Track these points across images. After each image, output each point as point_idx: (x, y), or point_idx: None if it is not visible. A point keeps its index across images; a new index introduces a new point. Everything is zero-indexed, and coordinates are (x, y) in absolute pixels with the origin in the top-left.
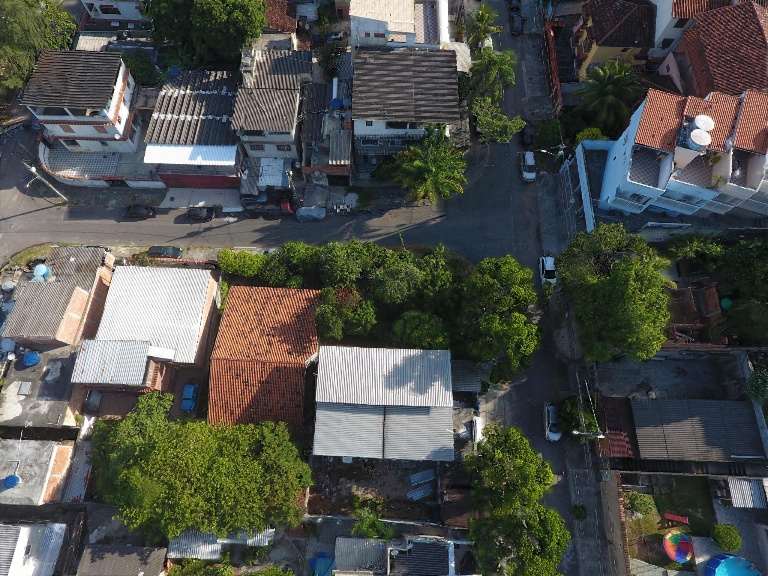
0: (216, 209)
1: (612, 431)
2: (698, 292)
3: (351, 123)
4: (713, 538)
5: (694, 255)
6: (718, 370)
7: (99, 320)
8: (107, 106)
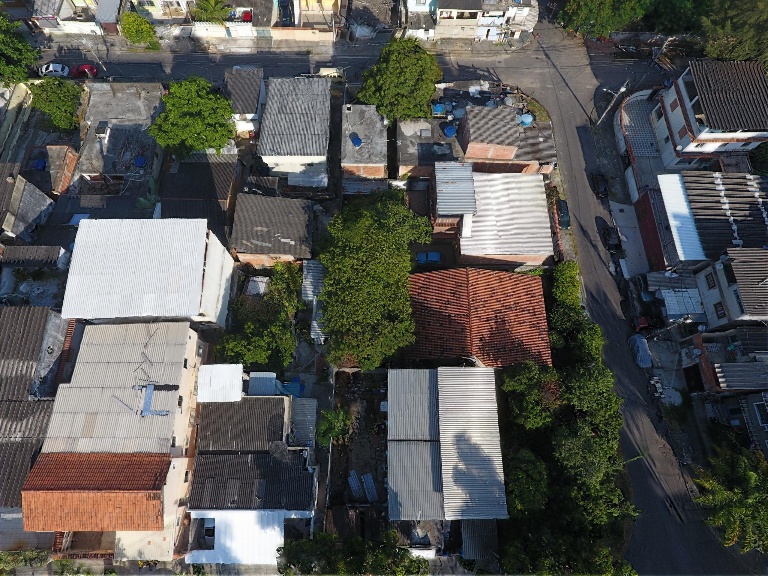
0: (621, 253)
1: None
2: None
3: None
4: None
5: None
6: None
7: None
8: (713, 130)
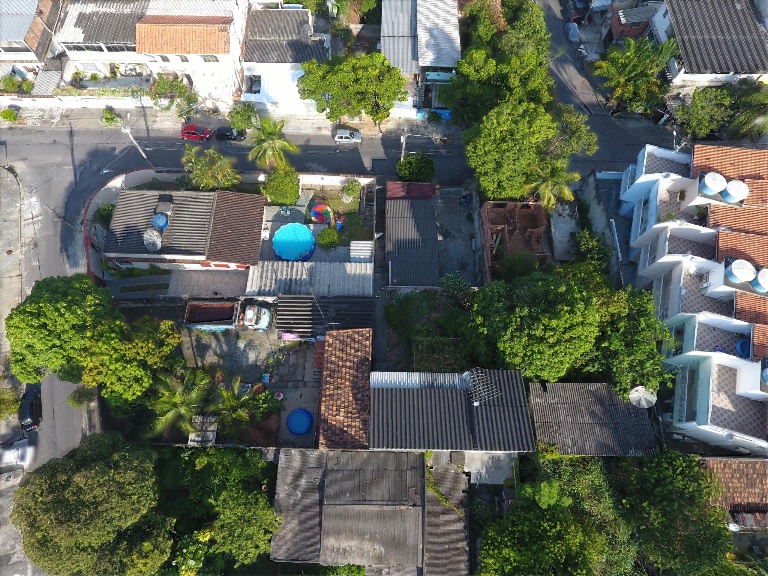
0: None
1: (407, 186)
2: None
3: None
4: None
5: (584, 250)
6: None
7: None
8: None
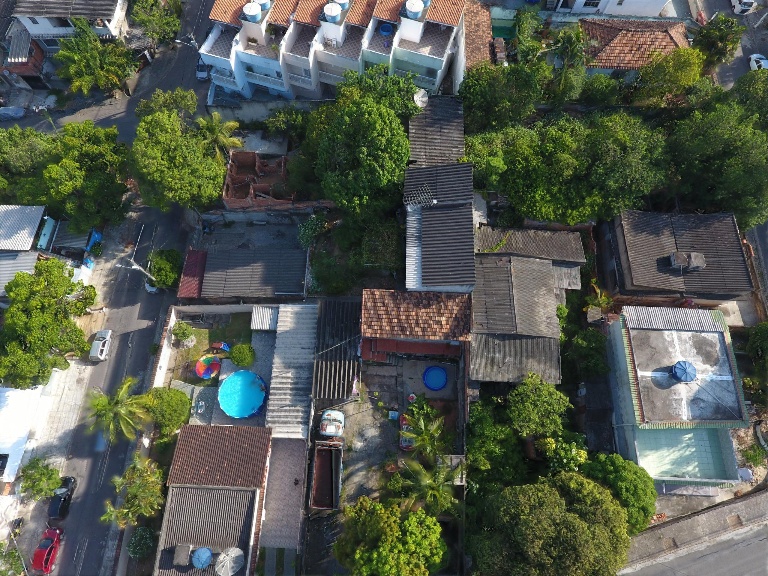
0: None
1: (186, 277)
2: None
3: None
4: None
5: (285, 126)
6: None
7: None
8: None
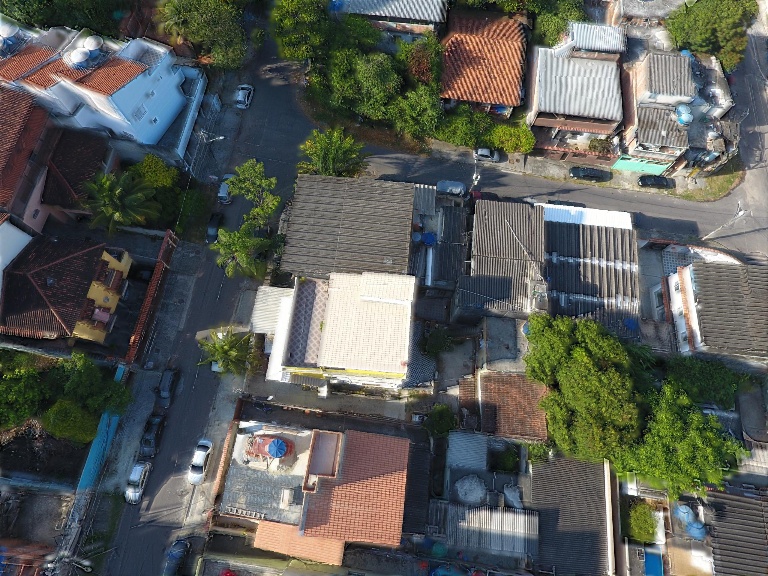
0: None
1: None
2: None
3: None
4: None
5: None
6: None
7: None
8: None
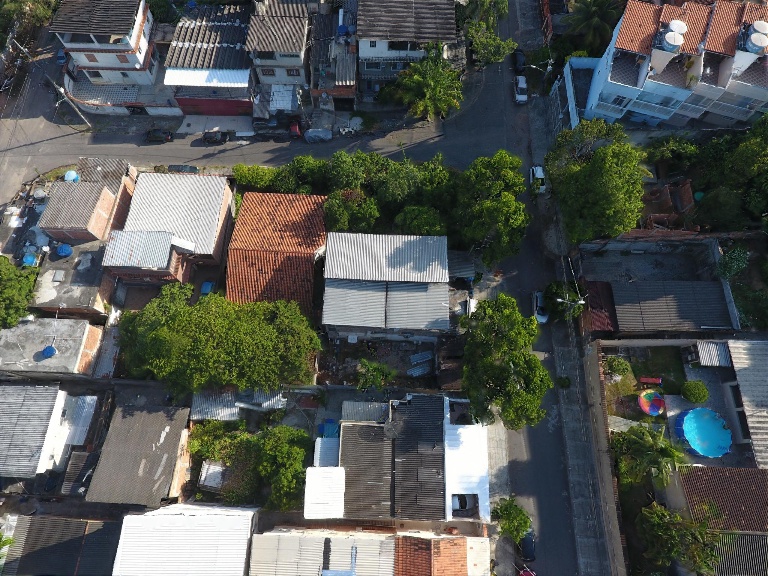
0: (230, 134)
1: (594, 309)
2: (675, 191)
3: (356, 46)
4: (683, 393)
5: (670, 155)
6: (693, 262)
7: (124, 222)
8: (129, 34)
